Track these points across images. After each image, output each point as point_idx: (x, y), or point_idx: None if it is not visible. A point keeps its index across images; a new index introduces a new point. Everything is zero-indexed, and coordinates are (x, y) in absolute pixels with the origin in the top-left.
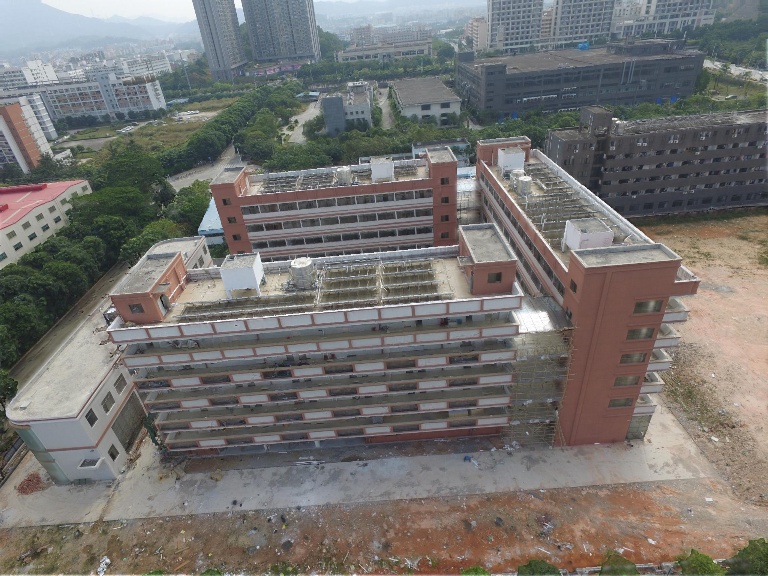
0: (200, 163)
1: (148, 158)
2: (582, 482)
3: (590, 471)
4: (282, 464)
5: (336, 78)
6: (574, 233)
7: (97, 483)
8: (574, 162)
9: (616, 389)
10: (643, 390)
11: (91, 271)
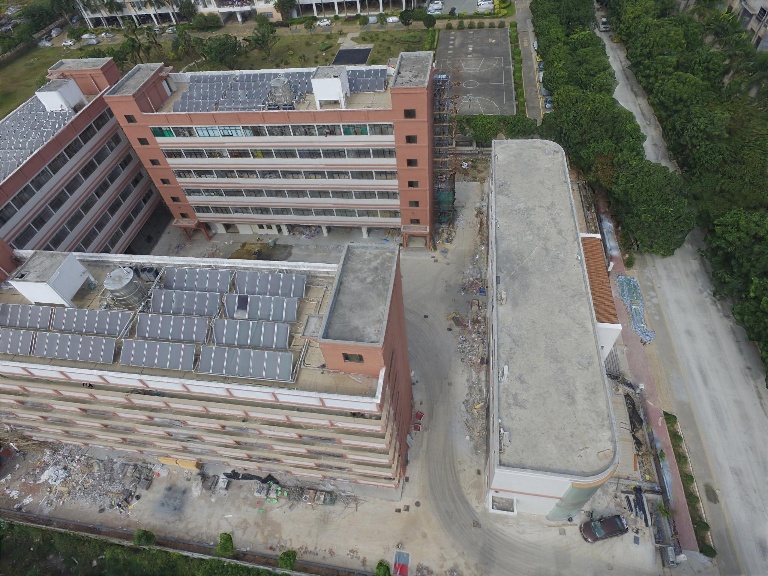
0: None
1: None
2: None
3: None
4: None
5: None
6: (69, 87)
7: None
8: None
9: None
10: None
11: None
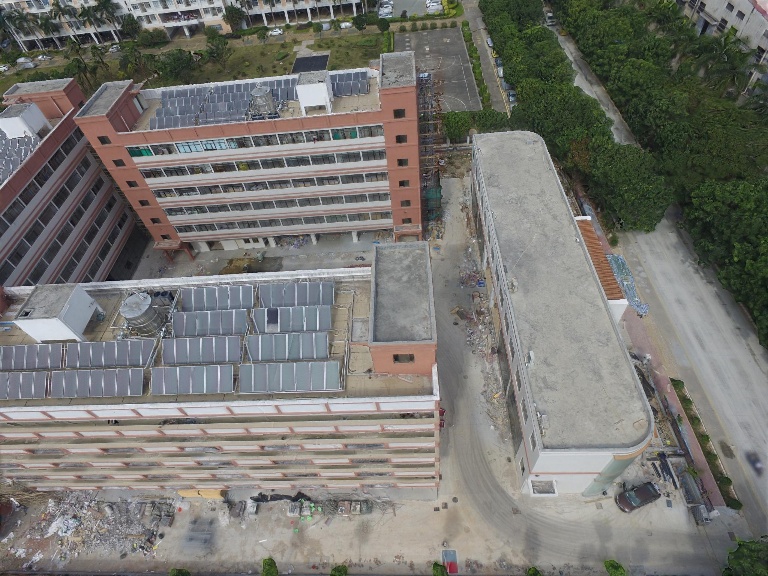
0: None
1: None
2: None
3: None
4: None
5: None
6: None
7: None
8: None
9: None
10: None
11: None
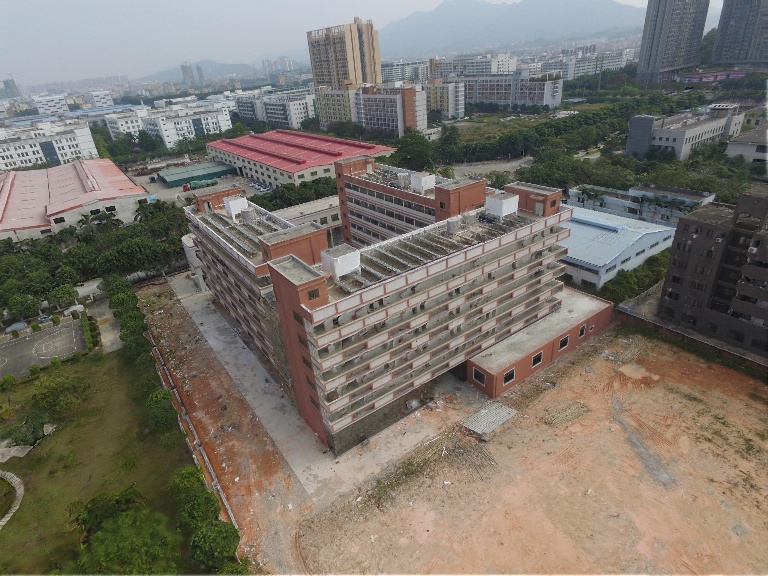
0: (501, 157)
1: (422, 142)
2: (274, 435)
3: (286, 437)
4: (232, 325)
5: (764, 95)
6: None
7: (198, 288)
8: (691, 250)
9: (308, 386)
10: (320, 402)
11: None
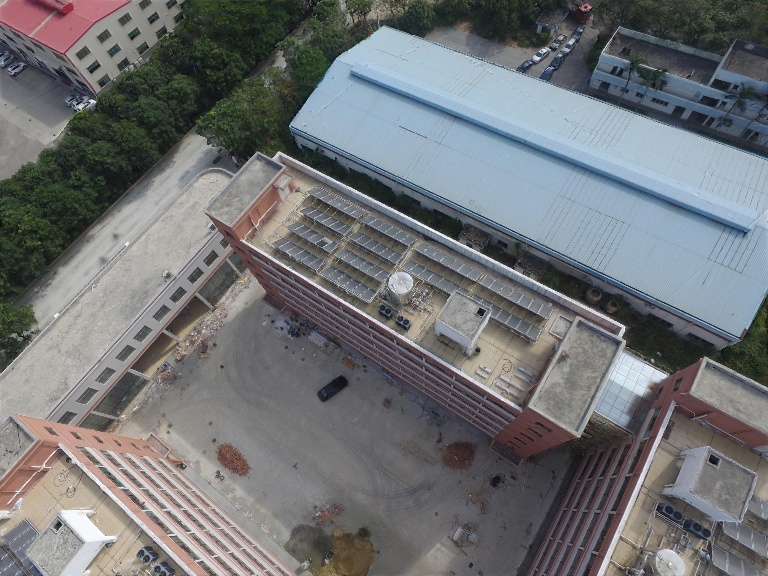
0: None
1: None
2: None
3: None
4: None
5: None
6: None
7: None
8: None
9: None
10: None
11: (167, 137)
